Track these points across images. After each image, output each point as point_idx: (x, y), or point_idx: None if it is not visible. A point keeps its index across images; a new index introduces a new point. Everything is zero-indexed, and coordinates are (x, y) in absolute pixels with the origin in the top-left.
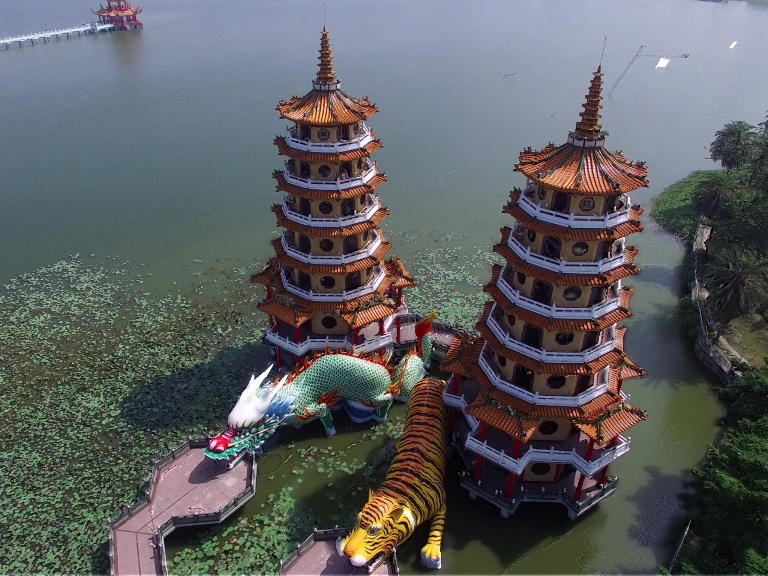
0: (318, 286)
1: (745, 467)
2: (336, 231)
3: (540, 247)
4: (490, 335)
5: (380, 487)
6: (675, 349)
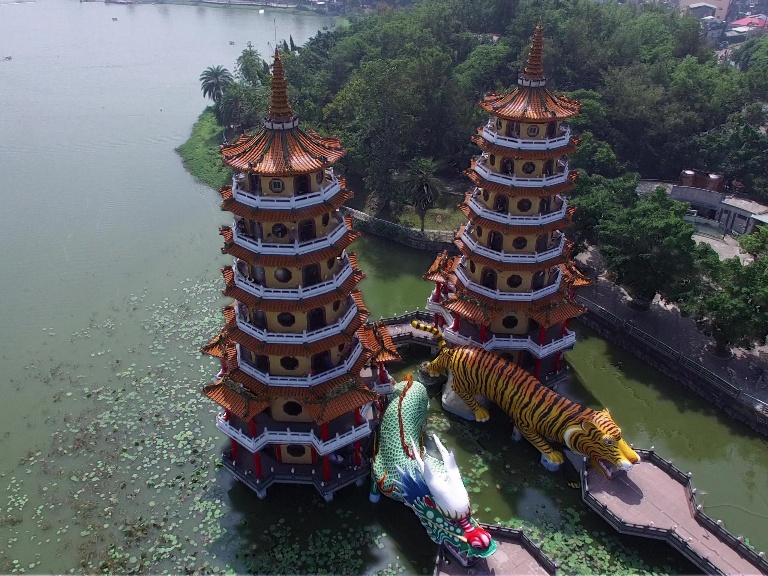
0: (338, 354)
1: (653, 234)
2: (355, 277)
3: (541, 173)
4: (517, 266)
5: (567, 423)
6: (404, 254)
